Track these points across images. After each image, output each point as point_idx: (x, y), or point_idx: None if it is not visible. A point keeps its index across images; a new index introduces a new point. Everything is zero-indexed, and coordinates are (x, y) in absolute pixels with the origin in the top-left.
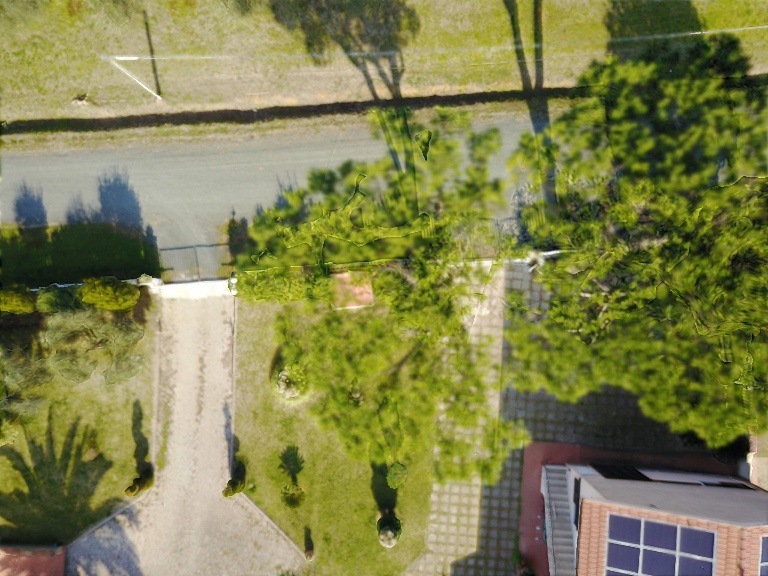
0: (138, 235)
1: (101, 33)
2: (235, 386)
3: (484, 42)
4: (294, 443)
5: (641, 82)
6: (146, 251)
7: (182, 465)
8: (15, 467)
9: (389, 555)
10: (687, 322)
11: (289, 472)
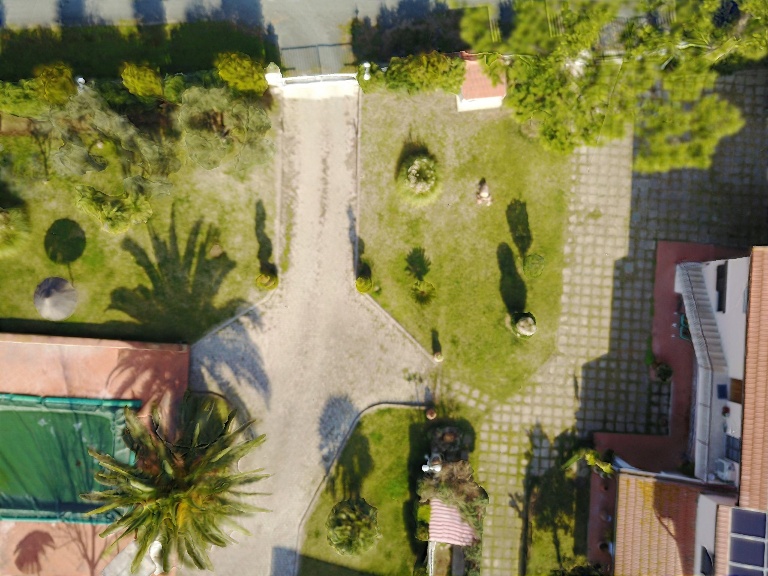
0: (259, 33)
1: None
2: (359, 187)
3: None
4: (420, 245)
5: None
6: (267, 50)
7: (306, 268)
8: (139, 263)
9: (519, 357)
10: None
11: (415, 274)
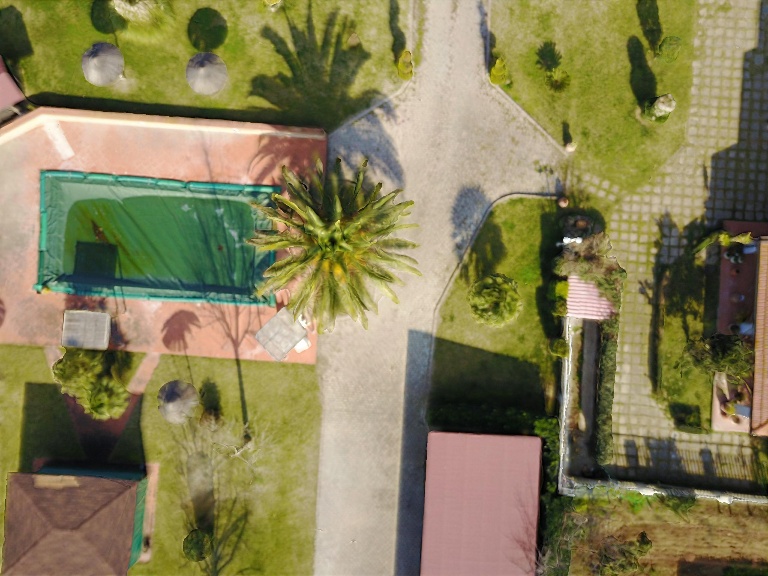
0: None
1: None
2: None
3: None
4: (551, 39)
5: None
6: None
7: (438, 62)
8: (279, 52)
9: (649, 148)
10: None
11: (546, 68)
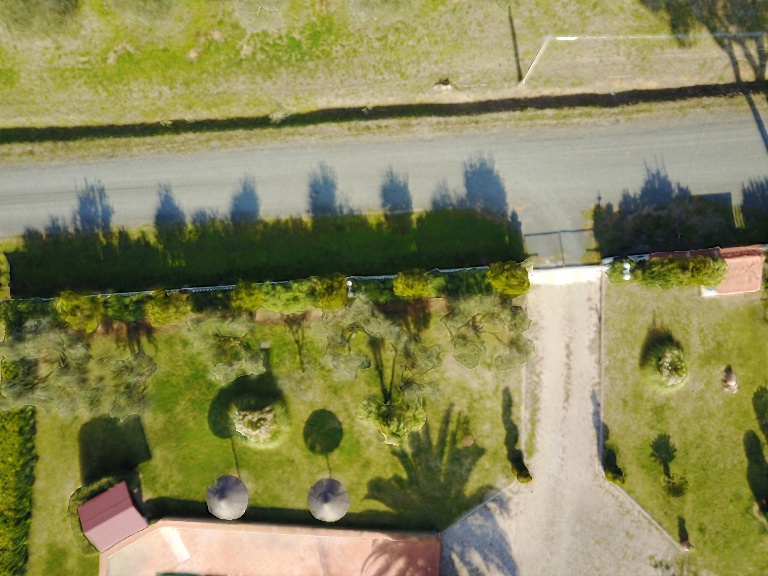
0: (502, 220)
1: (463, 17)
2: (603, 373)
3: None
4: (665, 431)
5: None
6: (510, 236)
7: (550, 453)
8: (393, 453)
9: (767, 546)
10: None
11: (661, 461)
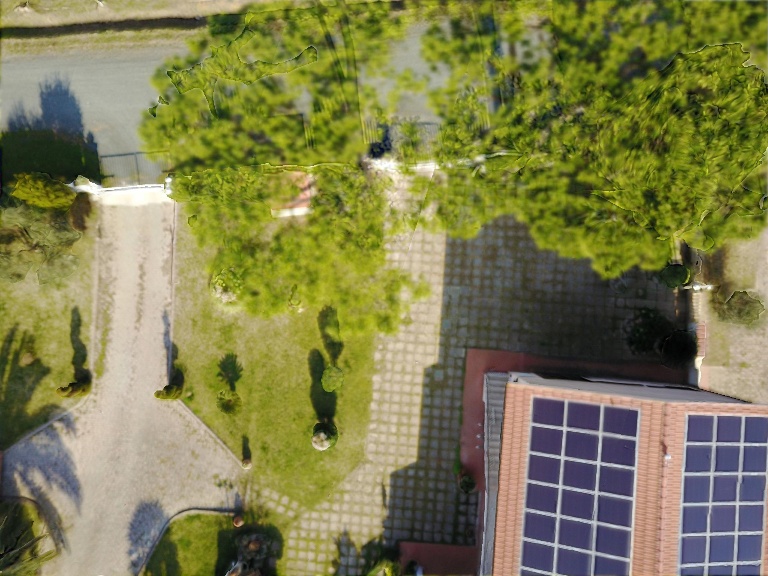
0: (79, 142)
1: None
2: (174, 293)
3: None
4: (233, 351)
5: None
6: (86, 158)
7: (120, 373)
8: None
9: (328, 465)
10: (634, 224)
11: (227, 380)
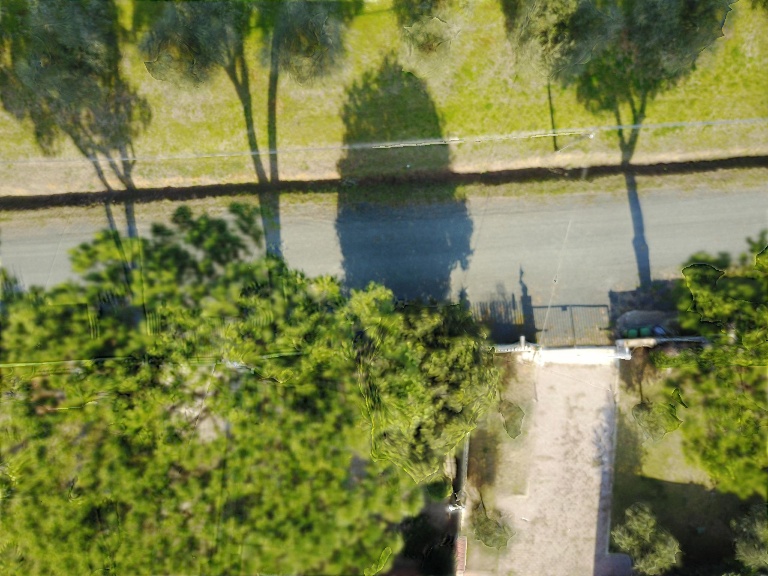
0: None
1: None
2: None
3: (216, 134)
4: (14, 540)
5: (380, 176)
6: None
7: None
8: None
9: None
10: None
11: (8, 569)
